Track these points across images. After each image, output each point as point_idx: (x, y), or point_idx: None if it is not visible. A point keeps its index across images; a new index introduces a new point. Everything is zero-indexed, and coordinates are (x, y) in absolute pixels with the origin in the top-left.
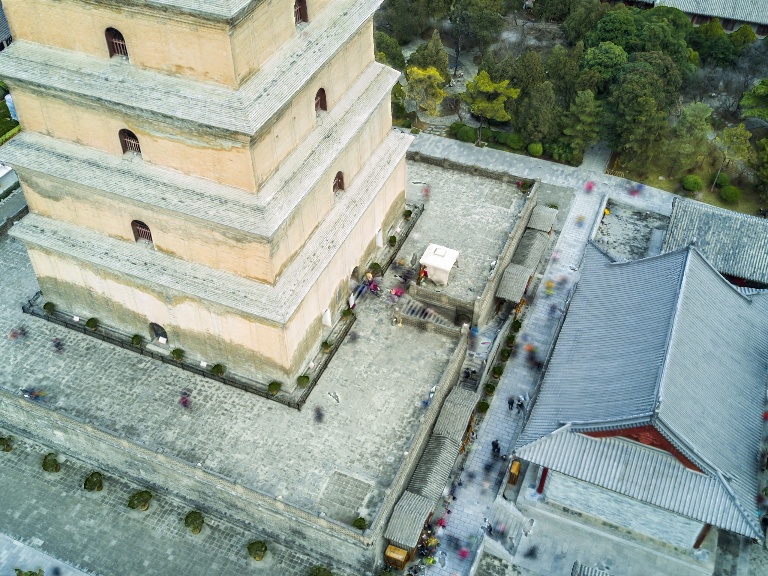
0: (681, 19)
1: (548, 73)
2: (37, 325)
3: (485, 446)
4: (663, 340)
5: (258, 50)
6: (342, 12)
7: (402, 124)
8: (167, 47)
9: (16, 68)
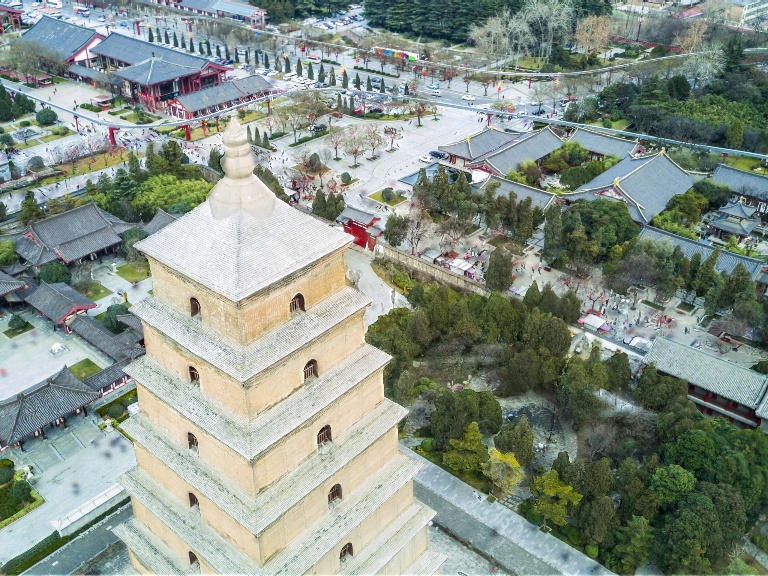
0: (764, 449)
1: (619, 478)
2: None
3: None
4: None
5: (287, 535)
6: (378, 484)
7: (482, 488)
8: (222, 522)
9: (134, 489)
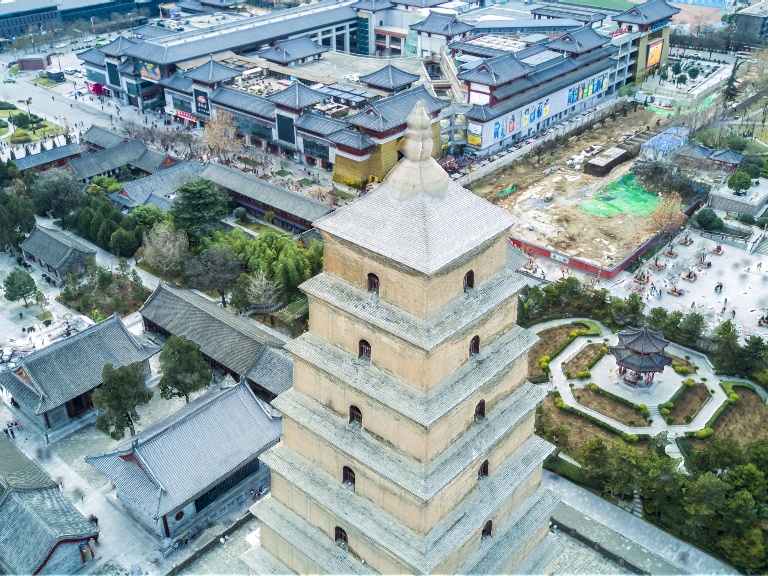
0: None
1: None
2: None
3: None
4: (206, 411)
5: None
6: None
7: None
8: None
9: None
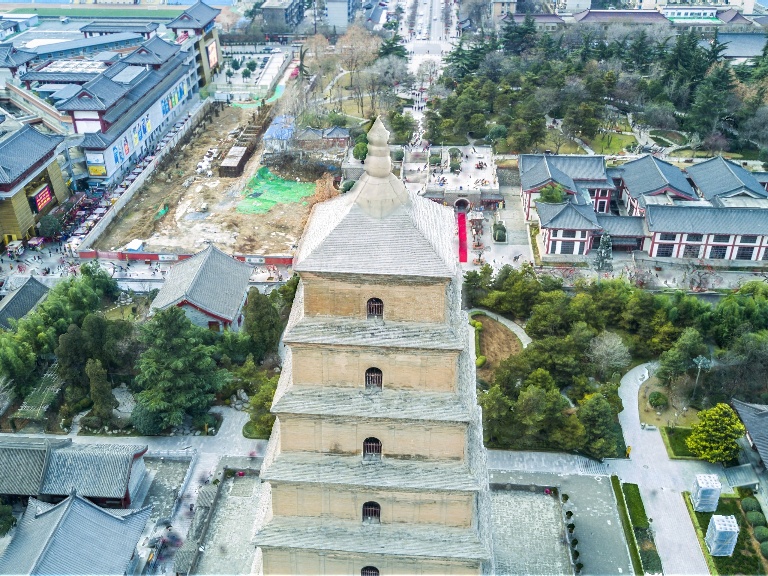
0: None
1: None
2: None
3: (171, 568)
4: (53, 546)
5: None
6: None
7: None
8: None
9: None
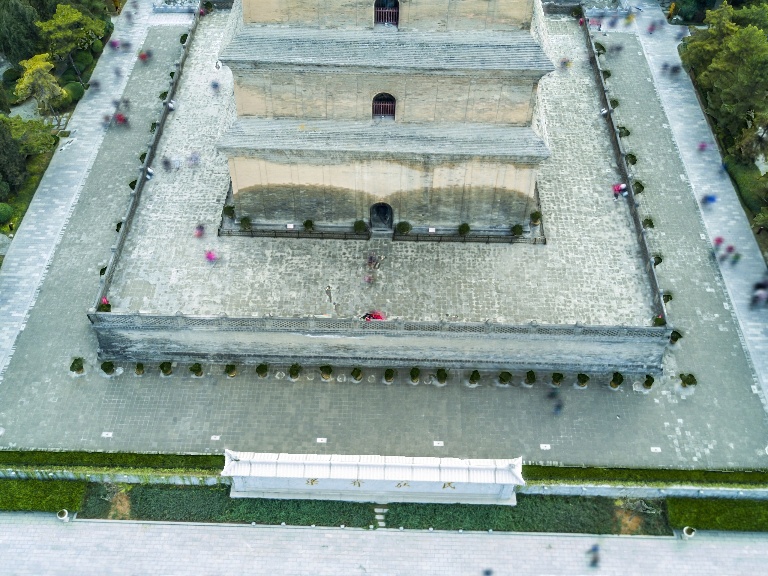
0: None
1: None
2: (552, 226)
3: None
4: None
5: None
6: None
7: None
8: None
9: None
